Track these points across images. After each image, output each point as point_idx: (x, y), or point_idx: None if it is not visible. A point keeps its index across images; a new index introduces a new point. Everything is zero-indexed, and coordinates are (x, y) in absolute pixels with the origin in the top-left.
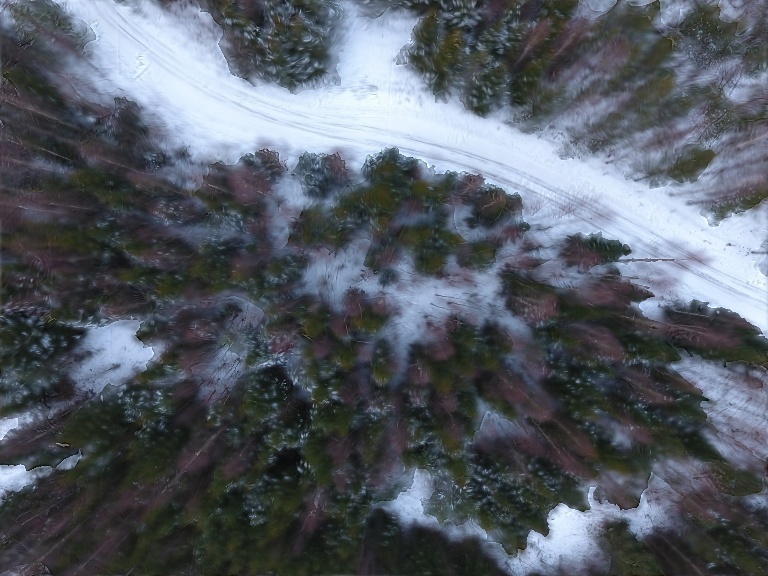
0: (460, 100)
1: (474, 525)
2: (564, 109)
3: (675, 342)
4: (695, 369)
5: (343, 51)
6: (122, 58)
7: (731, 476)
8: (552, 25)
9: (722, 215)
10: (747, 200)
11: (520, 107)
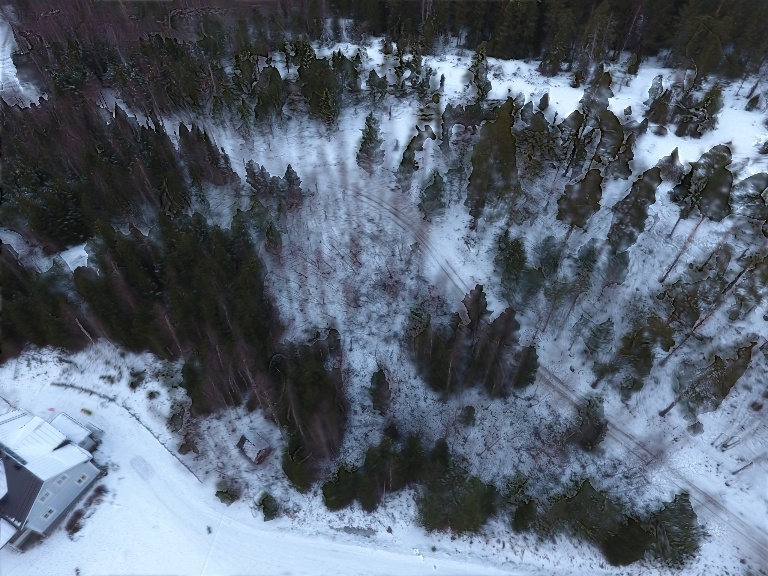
0: (130, 100)
1: (35, 260)
2: (164, 96)
3: (180, 156)
4: (207, 189)
5: (99, 99)
6: (12, 103)
7: (164, 175)
8: (156, 68)
9: (216, 119)
10: (215, 104)
11: (164, 113)
